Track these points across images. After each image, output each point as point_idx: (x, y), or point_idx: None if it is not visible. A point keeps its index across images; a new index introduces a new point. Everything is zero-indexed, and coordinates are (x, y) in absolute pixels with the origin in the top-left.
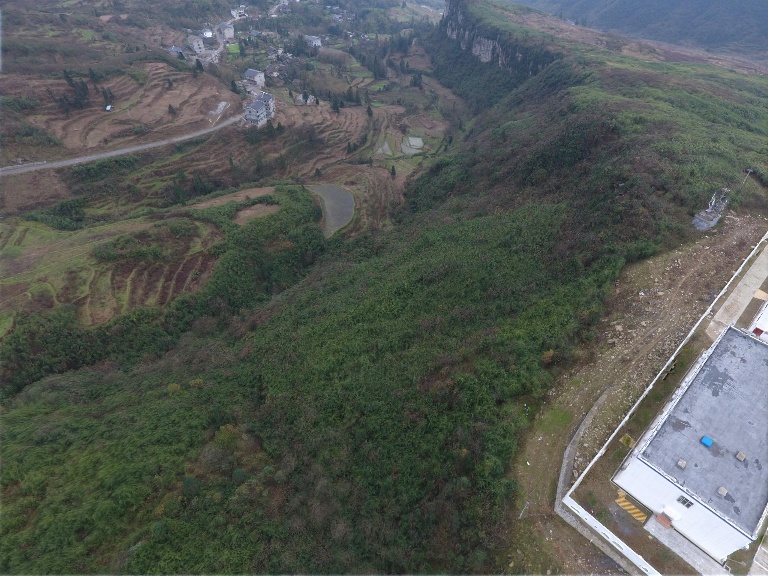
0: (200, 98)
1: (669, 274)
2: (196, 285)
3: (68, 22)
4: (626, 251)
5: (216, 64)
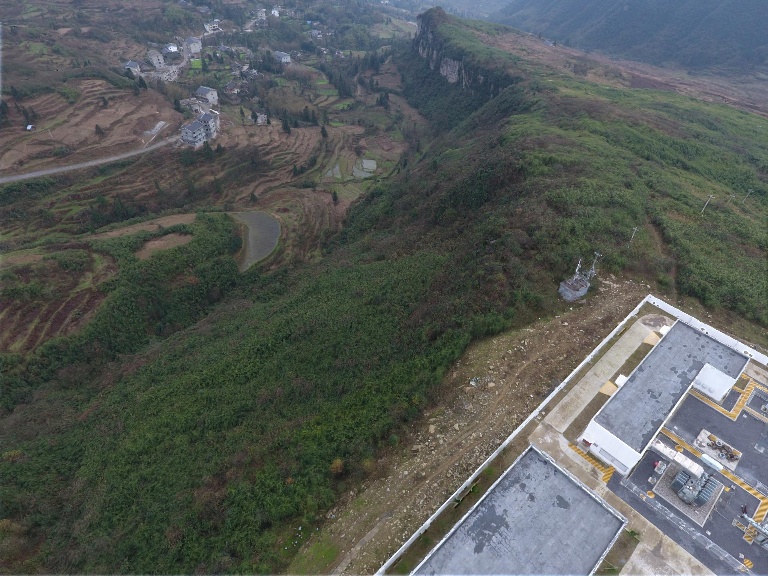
0: (136, 117)
1: (509, 359)
2: (75, 327)
3: (18, 35)
4: (472, 326)
5: (164, 81)
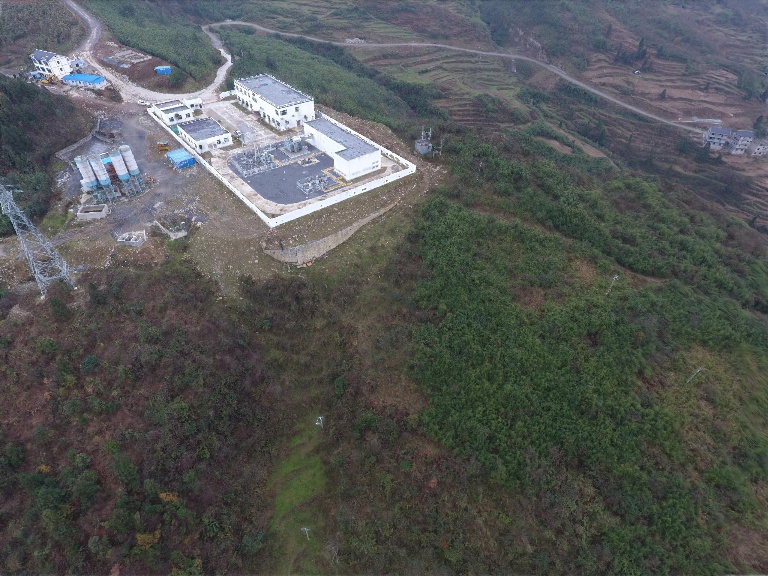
0: (706, 106)
1: None
2: None
3: None
4: None
5: None
